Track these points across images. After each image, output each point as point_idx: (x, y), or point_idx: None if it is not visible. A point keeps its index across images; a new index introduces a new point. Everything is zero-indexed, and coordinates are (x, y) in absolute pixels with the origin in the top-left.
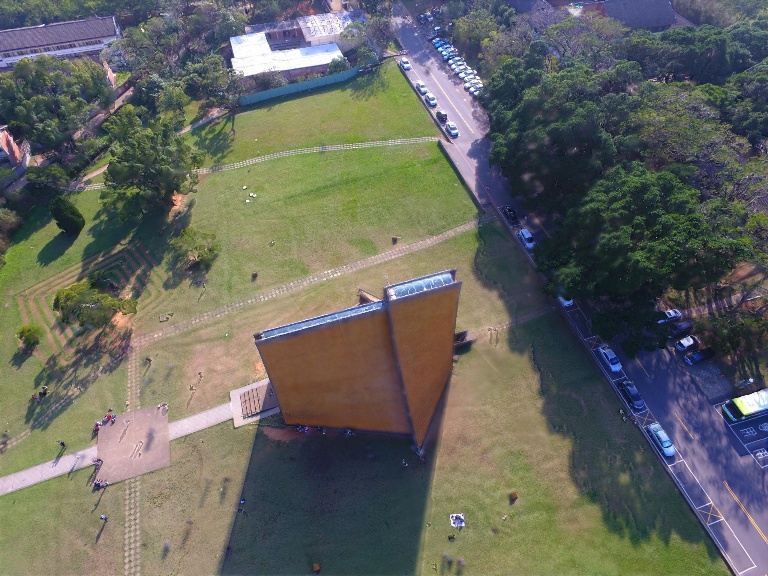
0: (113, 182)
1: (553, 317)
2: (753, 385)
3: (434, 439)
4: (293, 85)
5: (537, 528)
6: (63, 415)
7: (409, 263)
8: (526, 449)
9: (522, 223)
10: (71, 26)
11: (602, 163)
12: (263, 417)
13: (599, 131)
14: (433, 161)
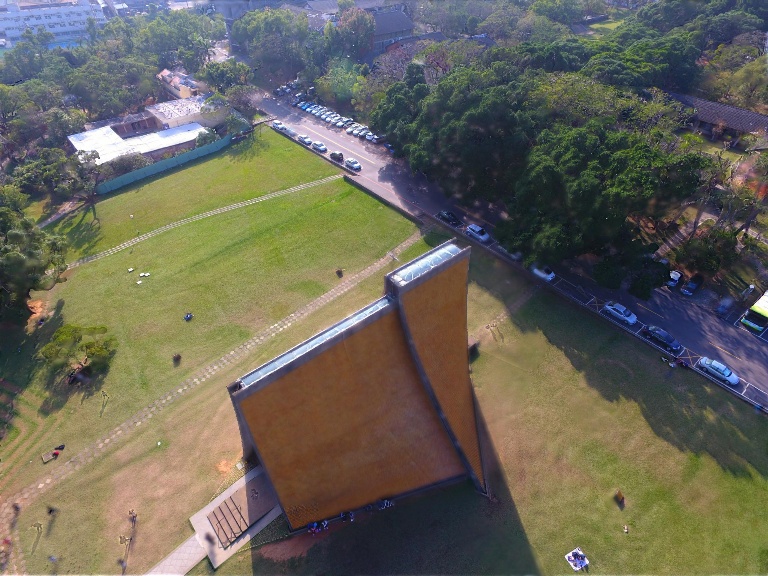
0: None
1: (543, 294)
2: (750, 295)
3: (494, 469)
4: (160, 162)
5: (667, 525)
6: None
7: (366, 291)
8: (598, 437)
9: (464, 223)
10: None
11: (526, 135)
12: (255, 534)
13: (509, 111)
14: (346, 194)
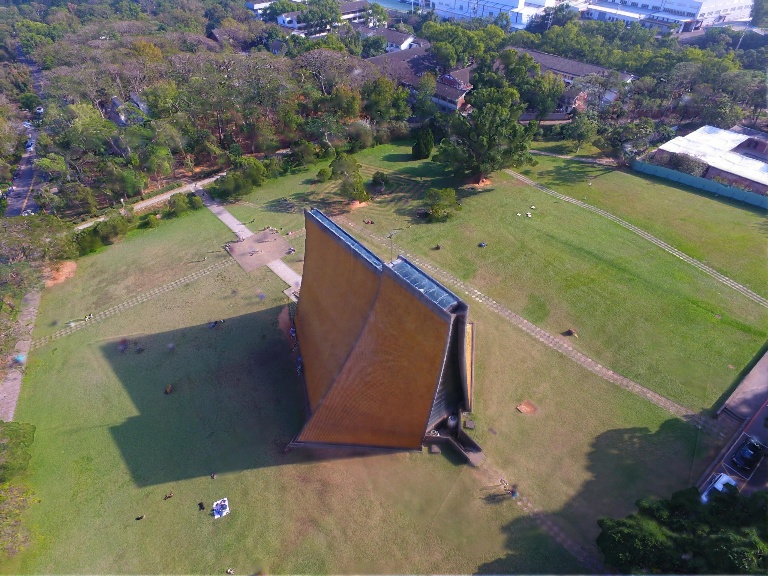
0: (462, 141)
1: None
2: None
3: (315, 454)
4: (703, 179)
5: None
6: (273, 213)
7: (546, 358)
8: None
9: (750, 480)
10: (596, 68)
11: None
12: (296, 303)
13: None
14: (745, 328)
